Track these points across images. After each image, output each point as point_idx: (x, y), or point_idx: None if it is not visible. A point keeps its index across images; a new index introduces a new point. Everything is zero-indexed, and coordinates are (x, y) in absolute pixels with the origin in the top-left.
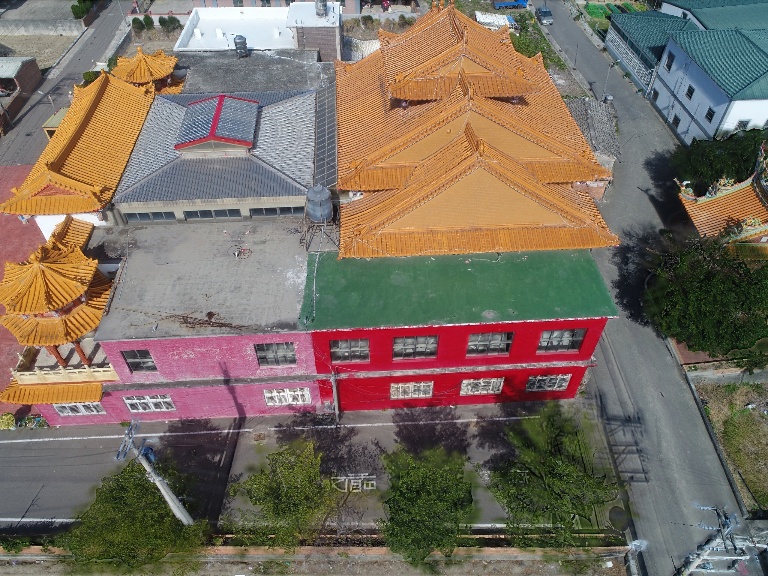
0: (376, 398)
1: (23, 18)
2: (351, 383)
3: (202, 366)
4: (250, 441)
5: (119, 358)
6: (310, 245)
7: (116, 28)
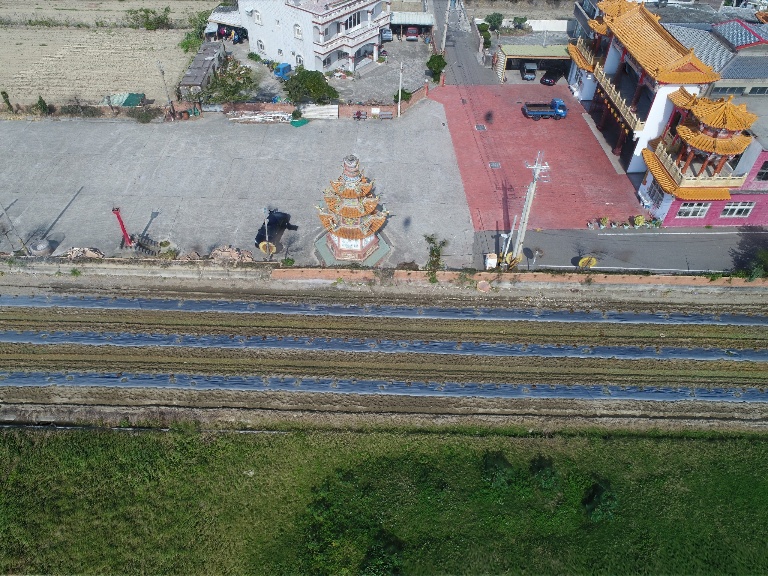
0: None
1: None
2: None
3: None
4: None
5: (758, 167)
6: None
7: None
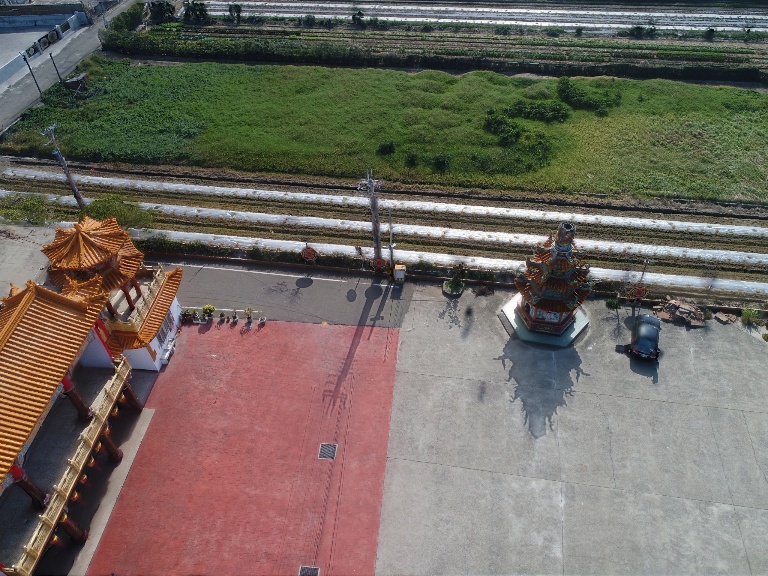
0: None
1: None
2: None
3: None
4: None
5: None
6: None
7: None
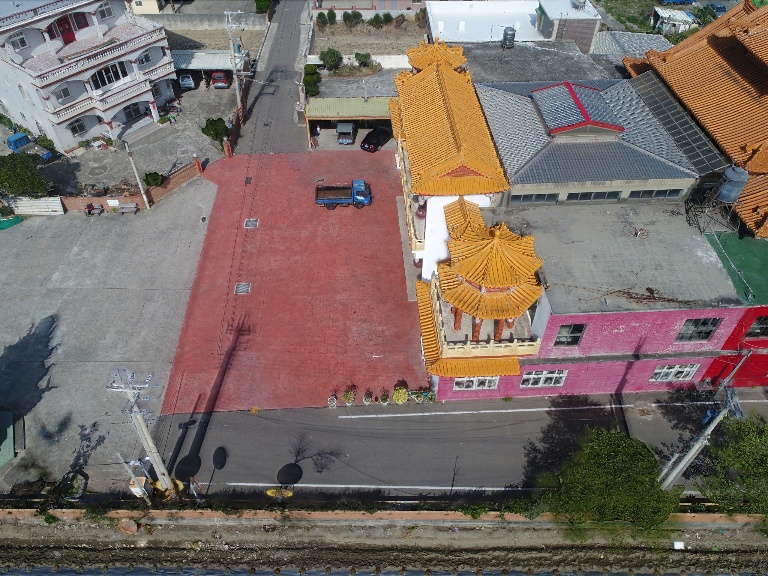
0: (754, 375)
1: (201, 13)
2: (748, 359)
3: (622, 341)
4: (637, 416)
5: (554, 332)
6: (700, 226)
7: (298, 23)
